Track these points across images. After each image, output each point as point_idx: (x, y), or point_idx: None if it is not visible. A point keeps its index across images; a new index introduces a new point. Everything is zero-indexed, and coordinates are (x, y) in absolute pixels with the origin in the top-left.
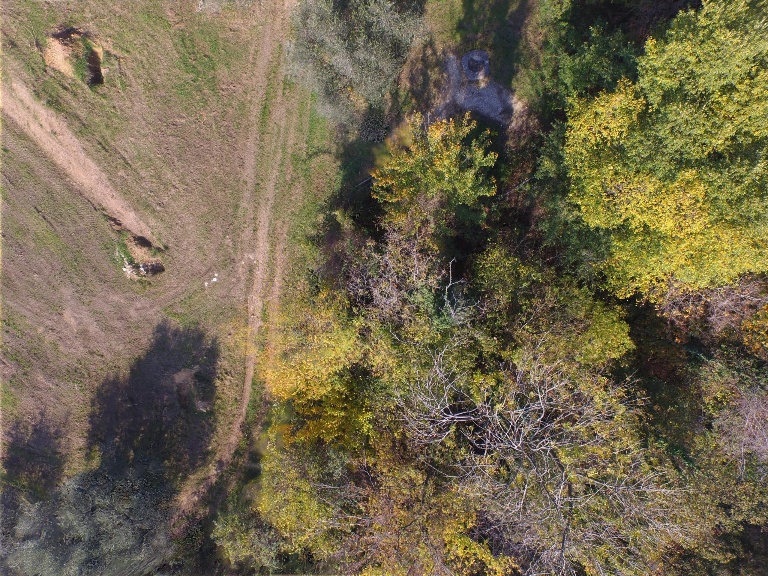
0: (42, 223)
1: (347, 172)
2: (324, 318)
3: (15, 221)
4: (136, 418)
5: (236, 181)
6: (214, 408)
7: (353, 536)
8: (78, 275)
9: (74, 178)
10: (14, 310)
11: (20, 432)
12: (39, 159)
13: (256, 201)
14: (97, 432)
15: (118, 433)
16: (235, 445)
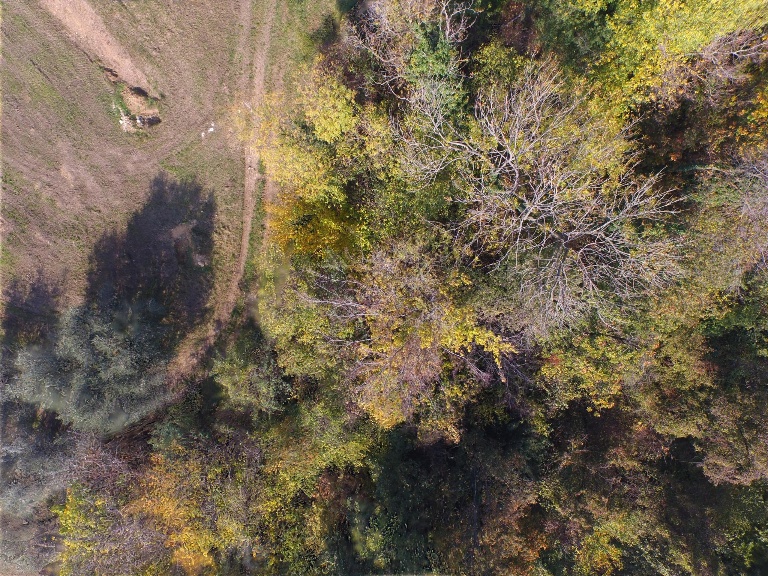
0: (38, 76)
1: (343, 11)
2: (321, 169)
3: (11, 75)
4: (134, 275)
5: (232, 25)
6: (212, 263)
7: (351, 345)
8: (75, 129)
9: (70, 29)
10: (11, 166)
11: (18, 291)
12: (34, 11)
13: (252, 46)
14: (95, 290)
15: (116, 291)
16: (233, 303)
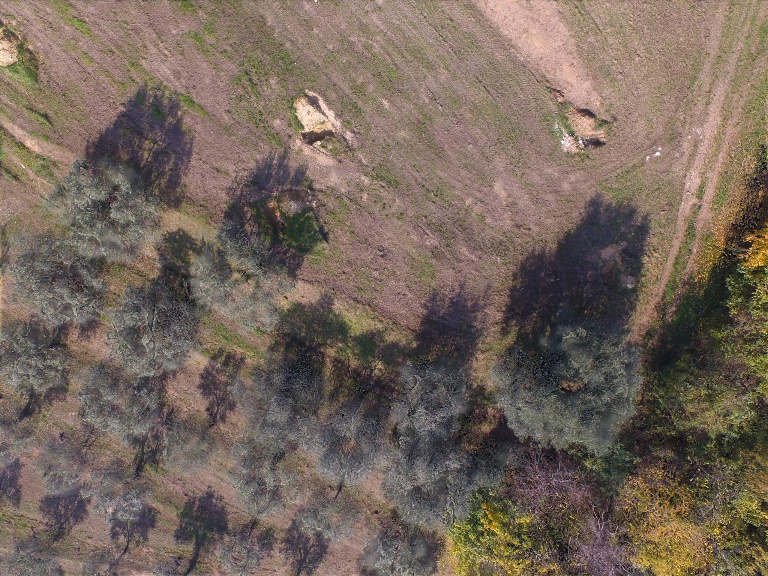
0: (483, 93)
1: None
2: (759, 197)
3: (454, 91)
4: (556, 294)
5: (698, 52)
6: (637, 286)
7: None
8: (514, 147)
9: (520, 49)
10: (443, 181)
11: (436, 304)
12: (484, 30)
13: (714, 74)
14: (515, 307)
15: (536, 308)
16: (647, 326)
